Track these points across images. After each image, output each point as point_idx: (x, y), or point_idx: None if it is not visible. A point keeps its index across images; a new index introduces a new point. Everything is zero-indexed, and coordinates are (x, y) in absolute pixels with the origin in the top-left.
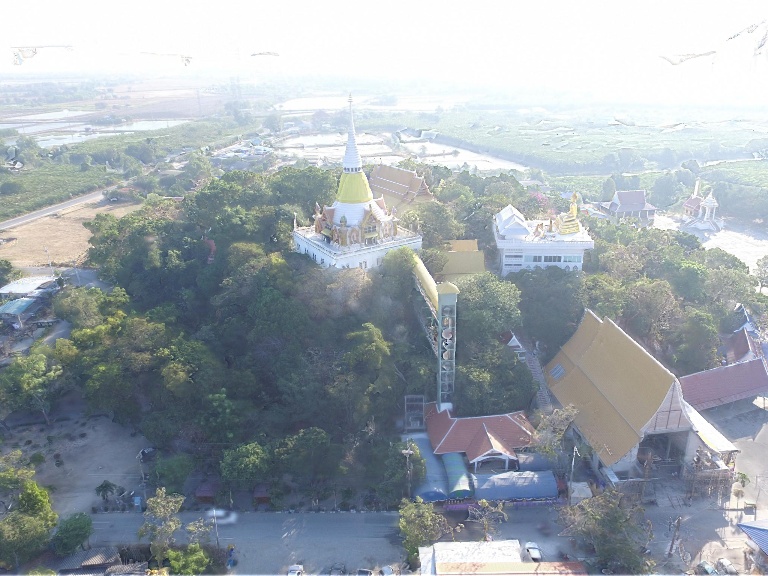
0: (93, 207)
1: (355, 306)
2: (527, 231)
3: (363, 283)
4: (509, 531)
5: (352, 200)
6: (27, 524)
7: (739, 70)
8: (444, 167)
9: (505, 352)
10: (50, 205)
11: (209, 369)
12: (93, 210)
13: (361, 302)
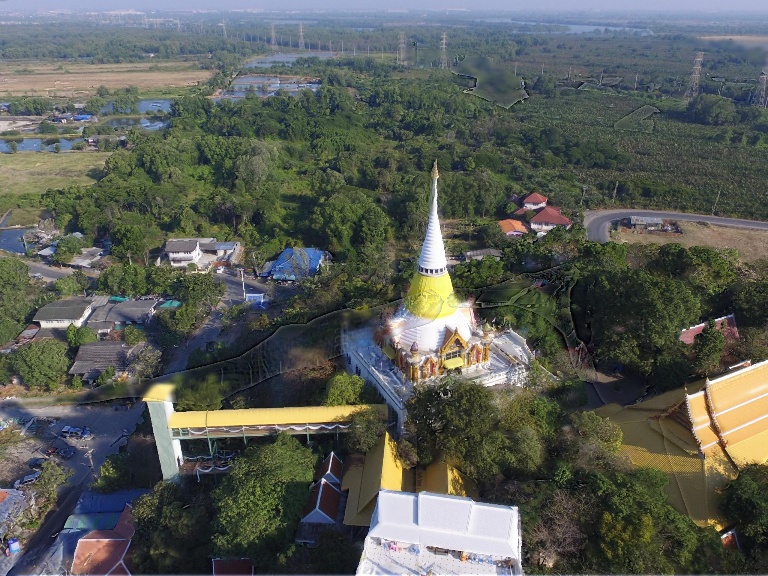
0: None
1: (292, 384)
2: (374, 524)
3: (305, 372)
4: (20, 570)
5: None
6: (163, 316)
7: None
8: None
9: (179, 537)
10: None
11: (258, 334)
12: None
13: (297, 387)
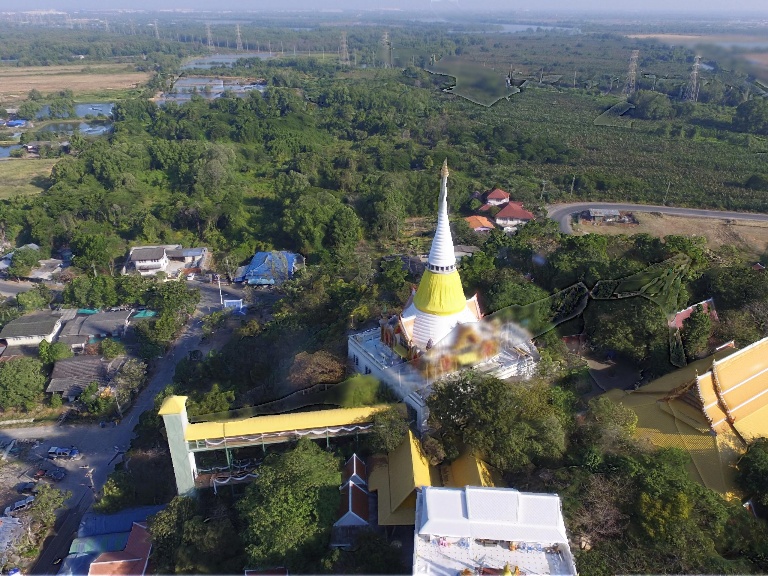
0: None
1: (299, 389)
2: (424, 521)
3: (314, 375)
4: None
5: None
6: (142, 326)
7: None
8: None
9: (205, 552)
10: (758, 212)
11: (250, 340)
12: (767, 233)
13: None
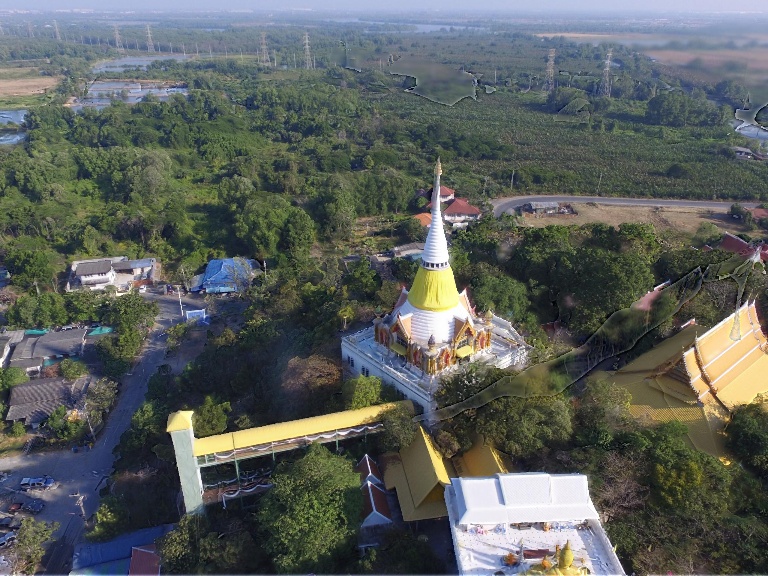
0: (702, 215)
1: (295, 394)
2: (462, 512)
3: (311, 380)
4: None
5: (408, 296)
6: (104, 344)
7: None
8: None
9: (227, 568)
10: (681, 198)
11: (228, 349)
12: (693, 218)
13: (302, 396)
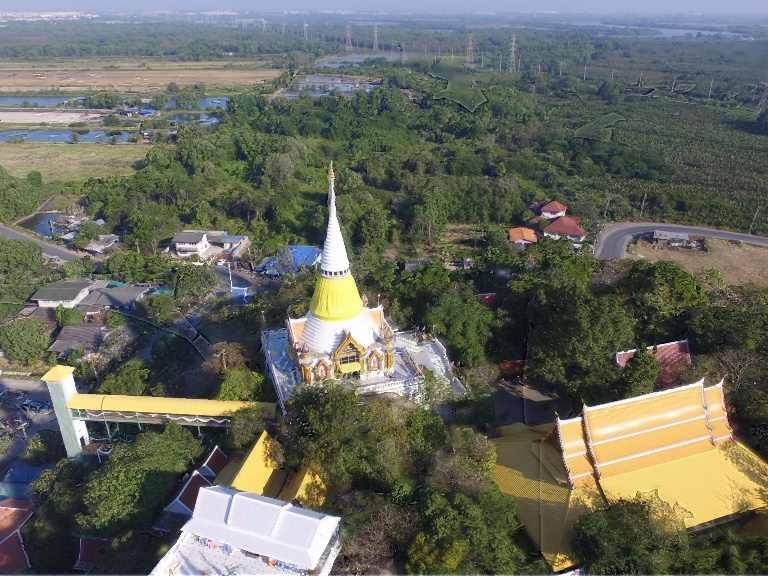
0: None
1: (211, 376)
2: None
3: None
4: None
5: None
6: None
7: None
8: None
9: (59, 513)
10: None
11: (213, 326)
12: None
13: None
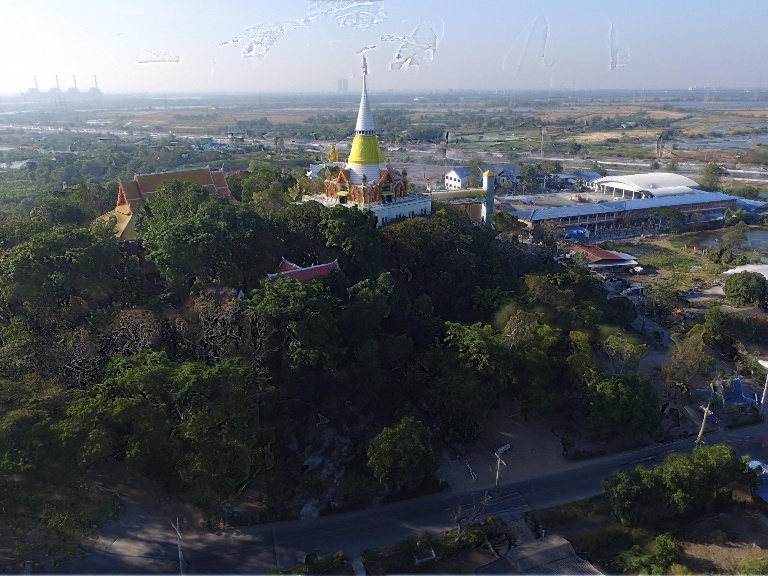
0: None
1: None
2: None
3: None
4: None
5: None
6: None
7: (235, 67)
8: (69, 189)
9: None
10: None
11: None
12: None
13: None
